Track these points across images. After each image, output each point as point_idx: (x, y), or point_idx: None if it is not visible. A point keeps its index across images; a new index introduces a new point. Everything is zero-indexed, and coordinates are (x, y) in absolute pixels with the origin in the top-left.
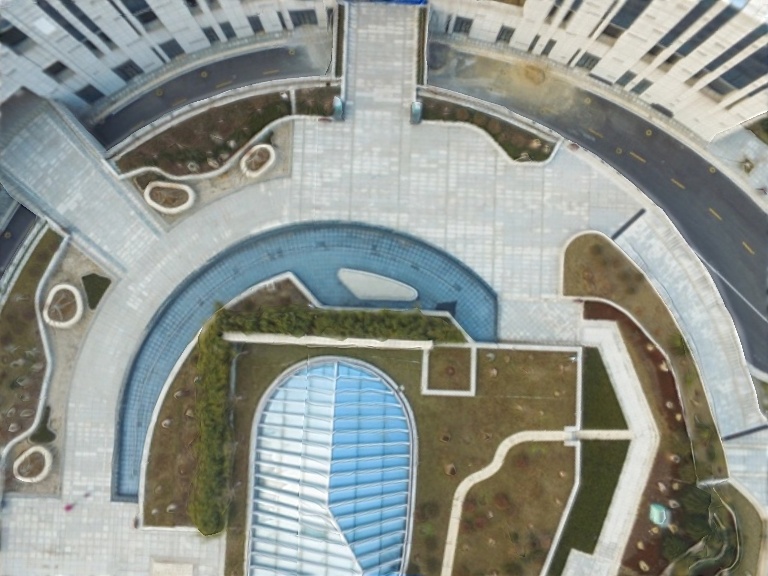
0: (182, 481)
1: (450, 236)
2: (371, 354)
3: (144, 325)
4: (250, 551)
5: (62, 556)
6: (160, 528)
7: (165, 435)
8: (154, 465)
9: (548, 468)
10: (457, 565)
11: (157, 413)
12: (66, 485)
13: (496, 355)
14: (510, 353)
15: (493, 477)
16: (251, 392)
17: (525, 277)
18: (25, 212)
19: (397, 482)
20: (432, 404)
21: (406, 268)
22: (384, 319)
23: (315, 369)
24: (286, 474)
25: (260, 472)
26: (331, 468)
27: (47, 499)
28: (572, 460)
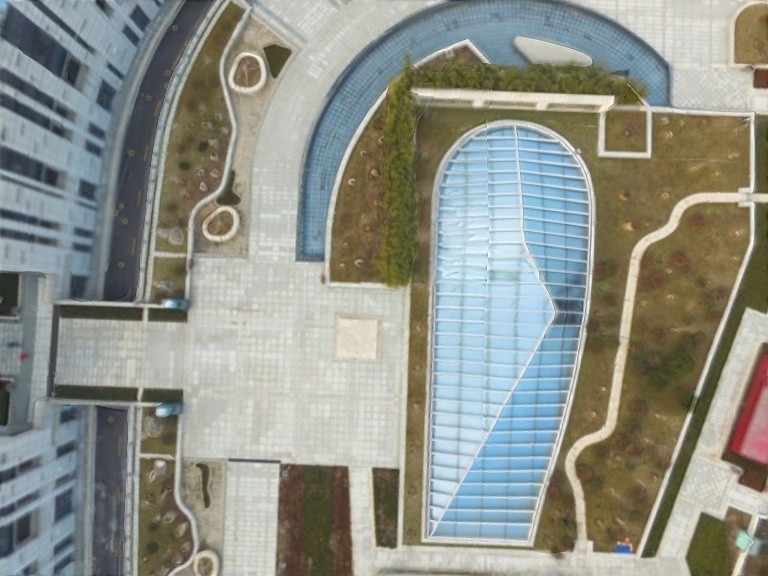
0: (368, 238)
1: (621, 8)
2: (548, 118)
3: (325, 93)
4: (435, 305)
5: (249, 313)
6: (346, 284)
7: (349, 195)
8: (339, 224)
9: (723, 229)
10: (636, 321)
11: (342, 173)
12: (252, 246)
13: (671, 118)
14: (684, 118)
15: (669, 237)
16: (432, 154)
17: (695, 47)
18: (193, 4)
19: (578, 238)
20: (608, 167)
21: (579, 38)
22: (570, 72)
23: (494, 132)
24: (473, 226)
25: (443, 230)
26: (523, 211)
27: (234, 259)
28: (747, 220)
